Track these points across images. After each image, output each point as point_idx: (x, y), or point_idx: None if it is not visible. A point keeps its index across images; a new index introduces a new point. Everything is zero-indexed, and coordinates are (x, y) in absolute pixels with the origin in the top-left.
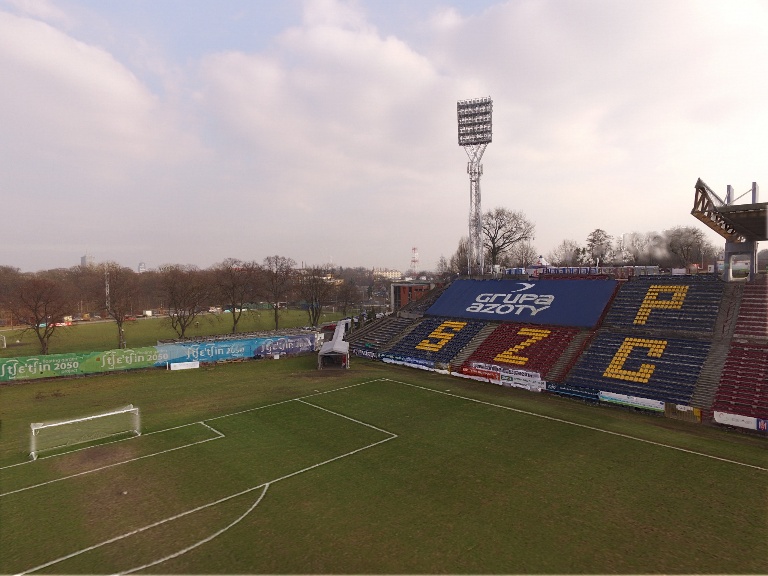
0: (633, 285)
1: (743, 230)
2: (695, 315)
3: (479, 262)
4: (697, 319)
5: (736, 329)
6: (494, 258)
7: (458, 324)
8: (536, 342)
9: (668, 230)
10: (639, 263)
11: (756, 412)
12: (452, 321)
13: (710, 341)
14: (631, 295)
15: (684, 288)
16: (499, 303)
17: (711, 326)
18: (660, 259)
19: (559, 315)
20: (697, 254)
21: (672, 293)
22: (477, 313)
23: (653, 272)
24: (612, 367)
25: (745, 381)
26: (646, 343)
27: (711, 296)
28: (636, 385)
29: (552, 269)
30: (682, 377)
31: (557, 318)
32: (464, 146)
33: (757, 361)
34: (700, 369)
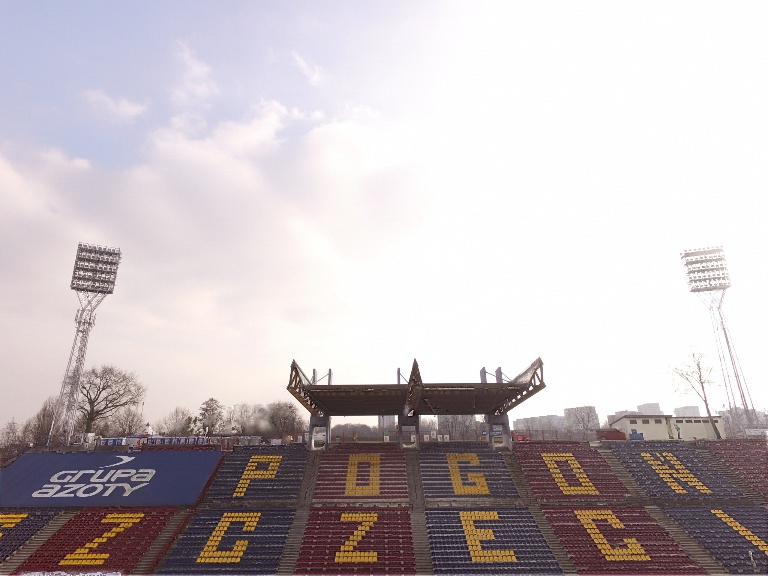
0: (237, 456)
1: (322, 406)
2: (285, 483)
3: (67, 429)
4: (287, 487)
5: (314, 494)
6: (89, 425)
7: (13, 517)
8: (124, 530)
9: (271, 403)
10: (245, 434)
11: (325, 574)
12: (4, 513)
13: (295, 508)
14: (234, 466)
15: (279, 457)
16: (84, 483)
17: (297, 493)
18: (263, 430)
19: (158, 493)
20: (291, 426)
21: (269, 463)
22: (48, 498)
23: (255, 442)
24: (207, 550)
25: (319, 544)
26: (242, 517)
27: (298, 464)
28: (228, 567)
29: (158, 439)
30: (271, 549)
31: (155, 497)
32: (77, 291)
33: (328, 523)
34: (286, 538)
